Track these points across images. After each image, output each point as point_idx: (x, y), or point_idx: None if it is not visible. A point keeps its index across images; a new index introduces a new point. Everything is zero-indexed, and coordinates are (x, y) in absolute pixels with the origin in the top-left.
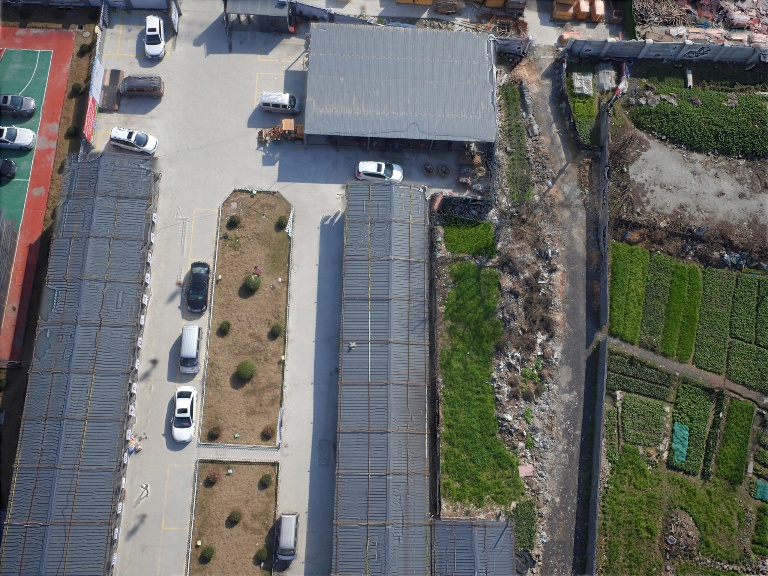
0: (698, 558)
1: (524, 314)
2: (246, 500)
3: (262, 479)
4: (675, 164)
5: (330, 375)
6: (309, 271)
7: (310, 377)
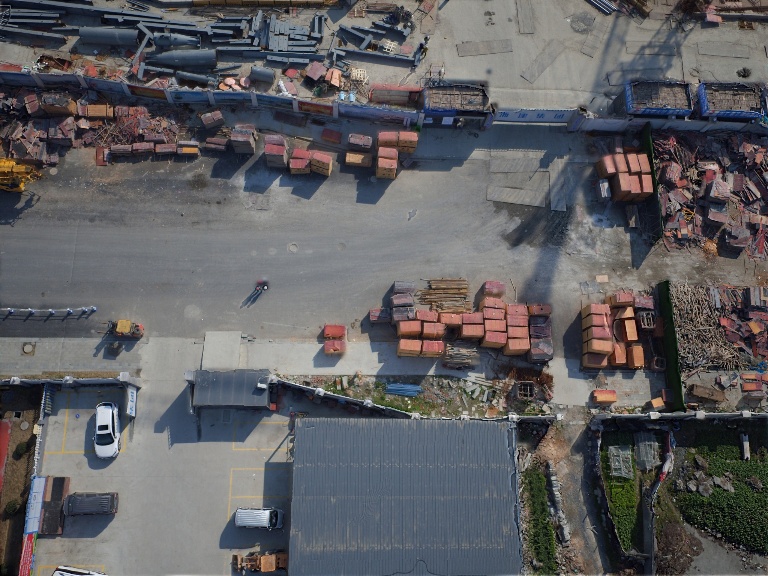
0: None
1: None
2: None
3: None
4: (733, 572)
5: None
6: None
7: None
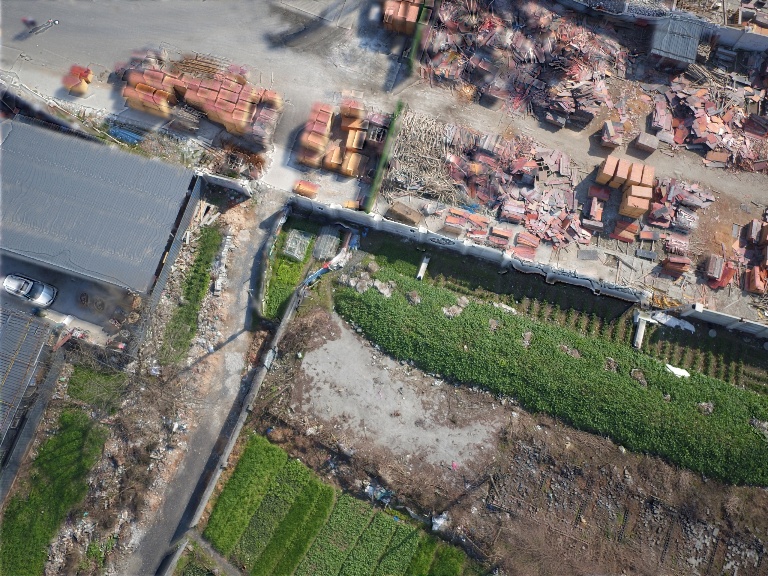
0: None
1: (120, 487)
2: None
3: None
4: (359, 364)
5: None
6: None
7: None
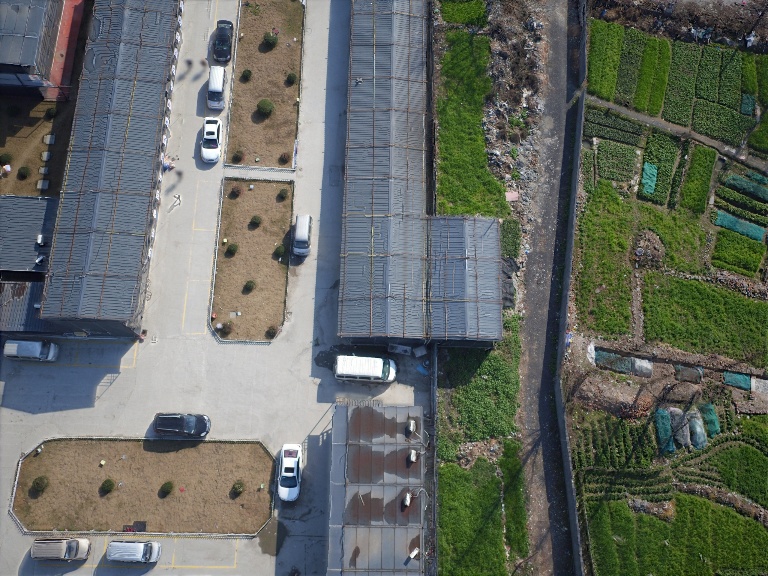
0: (664, 269)
1: (511, 74)
2: (266, 210)
3: (280, 192)
4: None
5: (339, 116)
6: (321, 33)
7: (322, 117)
